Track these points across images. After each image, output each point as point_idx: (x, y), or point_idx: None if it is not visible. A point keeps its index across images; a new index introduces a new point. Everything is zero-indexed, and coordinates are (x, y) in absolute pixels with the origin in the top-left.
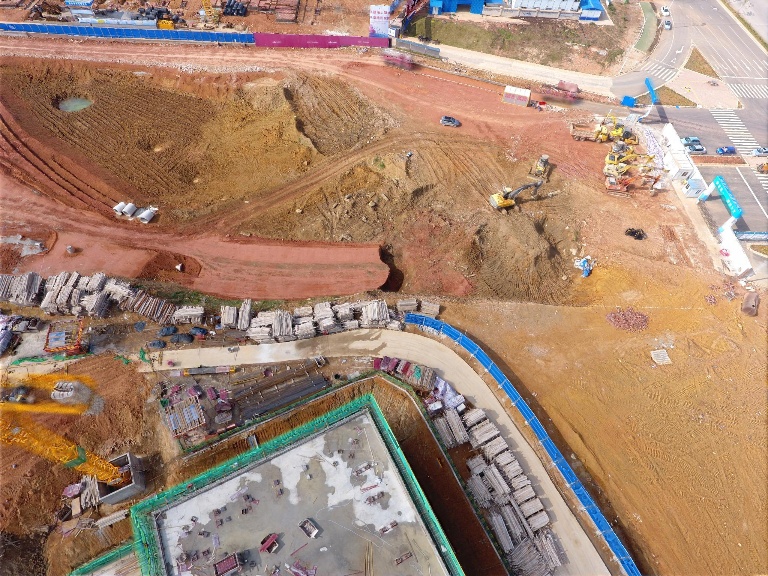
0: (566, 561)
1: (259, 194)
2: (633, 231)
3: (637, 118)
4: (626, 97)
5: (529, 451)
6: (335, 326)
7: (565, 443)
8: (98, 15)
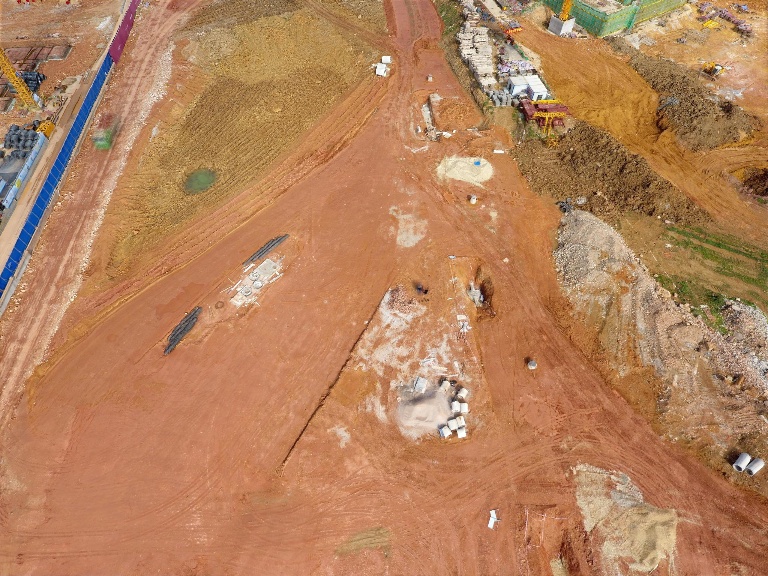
0: None
1: None
2: None
3: None
4: None
5: None
6: None
7: None
8: None
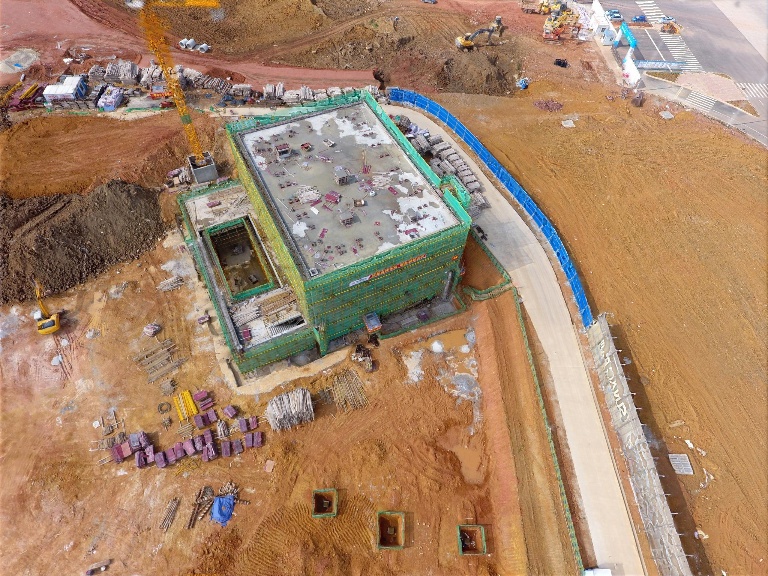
0: (490, 207)
1: (284, 41)
2: (559, 60)
3: None
4: None
5: (471, 161)
6: (342, 98)
7: (496, 159)
8: None
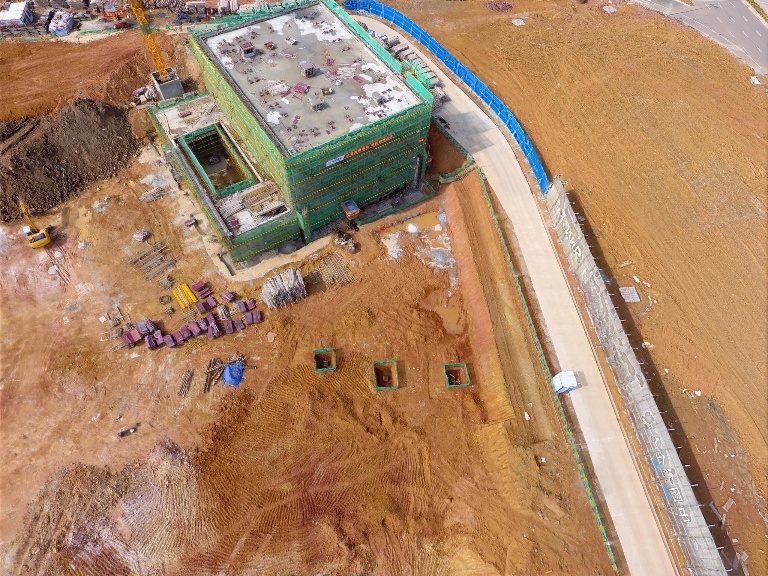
0: (450, 100)
1: None
2: None
3: None
4: None
5: (429, 61)
6: None
7: None
8: None
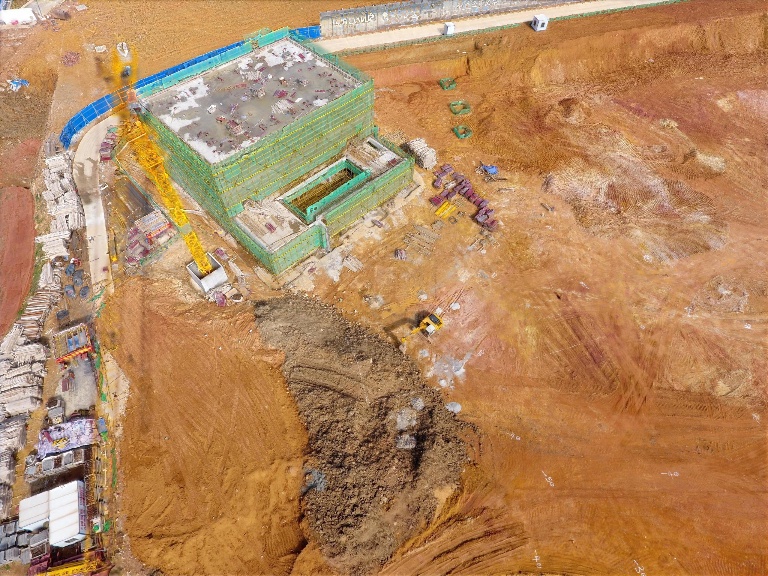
0: None
1: None
2: None
3: None
4: None
5: None
6: None
7: None
8: None
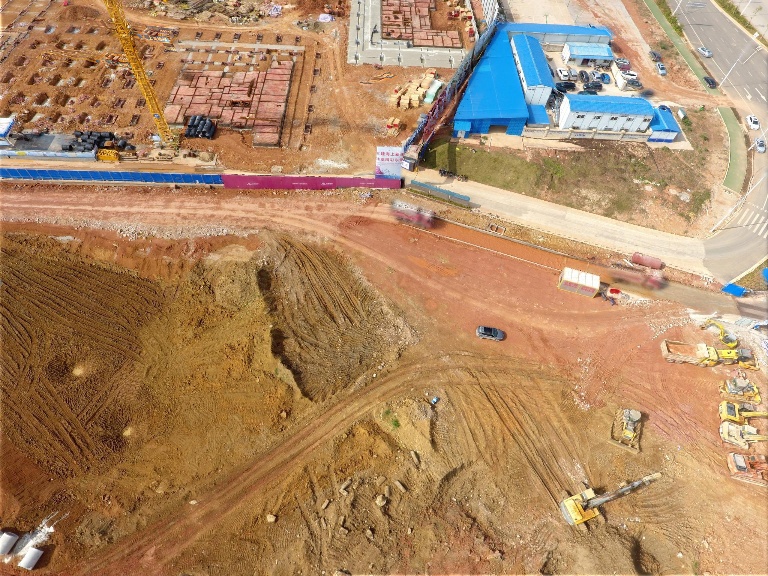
0: None
1: (212, 485)
2: None
3: (753, 325)
4: (732, 285)
5: None
6: None
7: None
8: (20, 141)
